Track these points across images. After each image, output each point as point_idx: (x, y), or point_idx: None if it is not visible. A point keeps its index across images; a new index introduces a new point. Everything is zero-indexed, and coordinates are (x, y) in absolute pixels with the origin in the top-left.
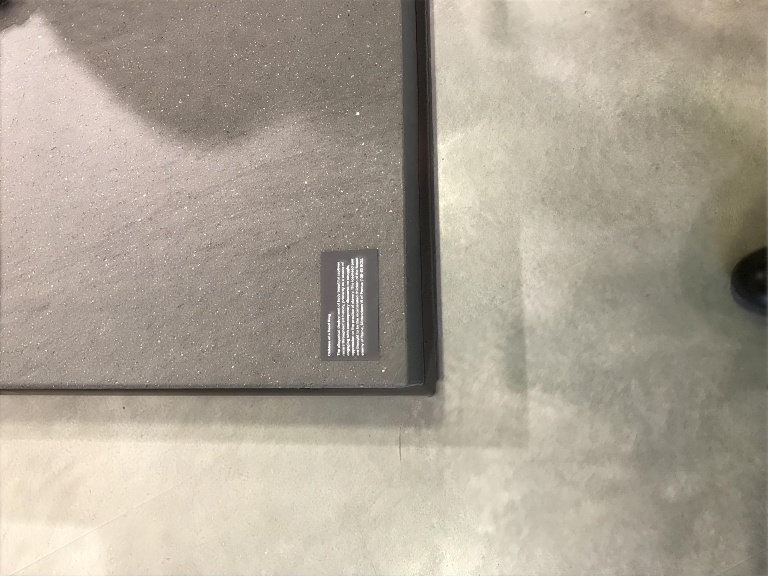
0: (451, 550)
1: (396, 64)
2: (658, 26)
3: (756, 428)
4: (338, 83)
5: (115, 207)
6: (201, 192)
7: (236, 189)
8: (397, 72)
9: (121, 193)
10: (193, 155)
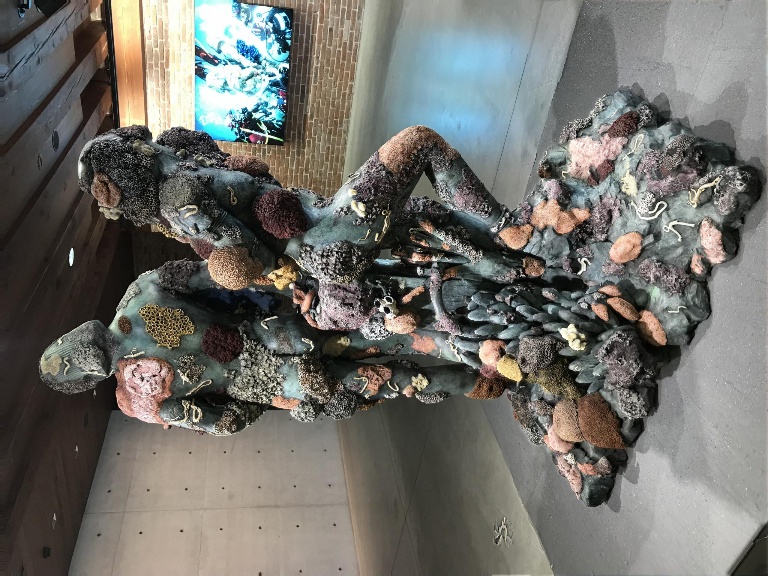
0: None
1: (575, 26)
2: None
3: None
4: None
5: (628, 3)
6: (613, 2)
7: (608, 0)
8: (576, 23)
9: (625, 8)
10: None
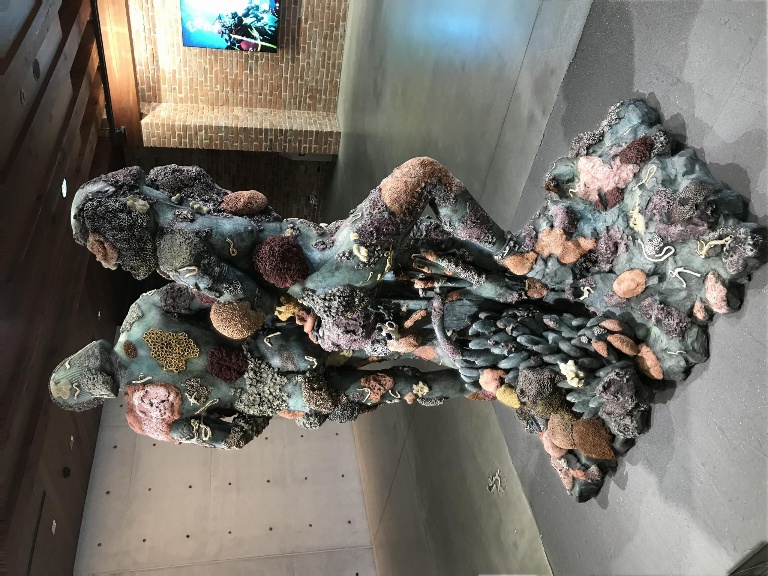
0: None
1: (592, 4)
2: (589, 3)
3: None
4: (601, 6)
5: None
6: None
7: None
8: (593, 1)
9: (647, 2)
10: (630, 5)
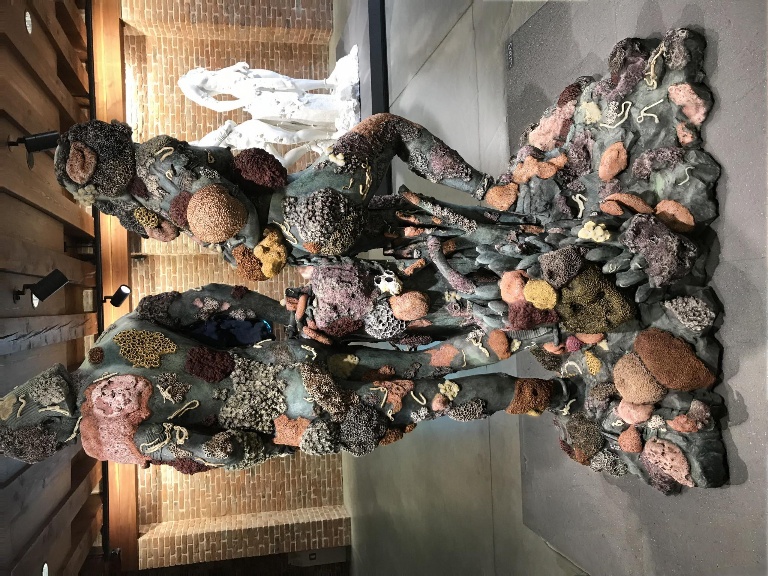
0: (529, 4)
1: None
2: None
3: (503, 62)
4: None
5: None
6: None
7: None
8: None
9: None
10: None
